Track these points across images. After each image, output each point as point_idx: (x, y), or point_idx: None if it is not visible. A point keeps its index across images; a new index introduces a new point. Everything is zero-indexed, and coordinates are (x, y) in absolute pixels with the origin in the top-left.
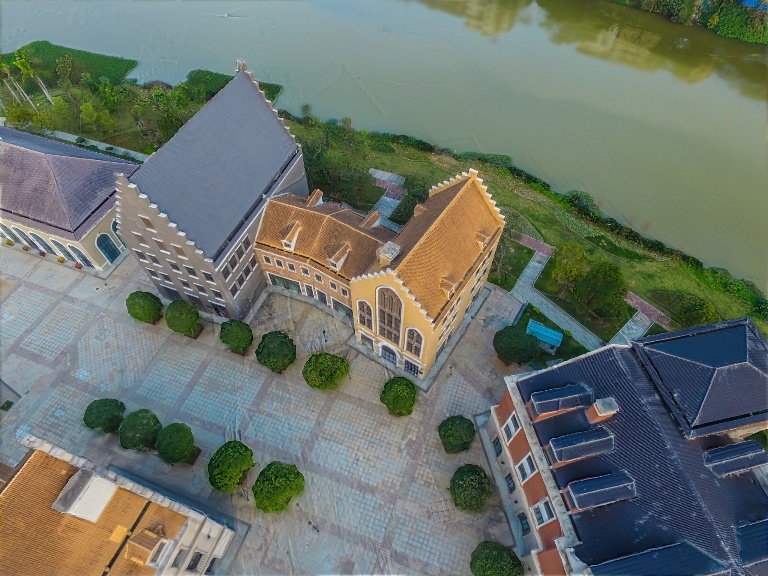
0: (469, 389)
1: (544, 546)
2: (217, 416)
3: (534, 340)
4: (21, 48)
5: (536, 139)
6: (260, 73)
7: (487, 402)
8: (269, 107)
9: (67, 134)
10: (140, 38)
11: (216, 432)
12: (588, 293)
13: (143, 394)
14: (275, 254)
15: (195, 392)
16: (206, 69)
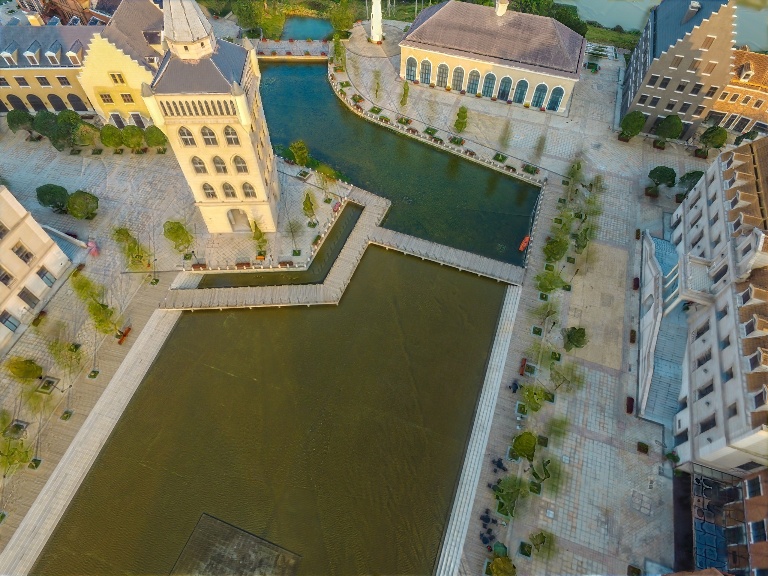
0: None
1: None
2: None
3: None
4: None
5: None
6: None
7: None
8: None
9: None
10: None
11: None
12: None
13: None
14: (731, 85)
15: None
16: None
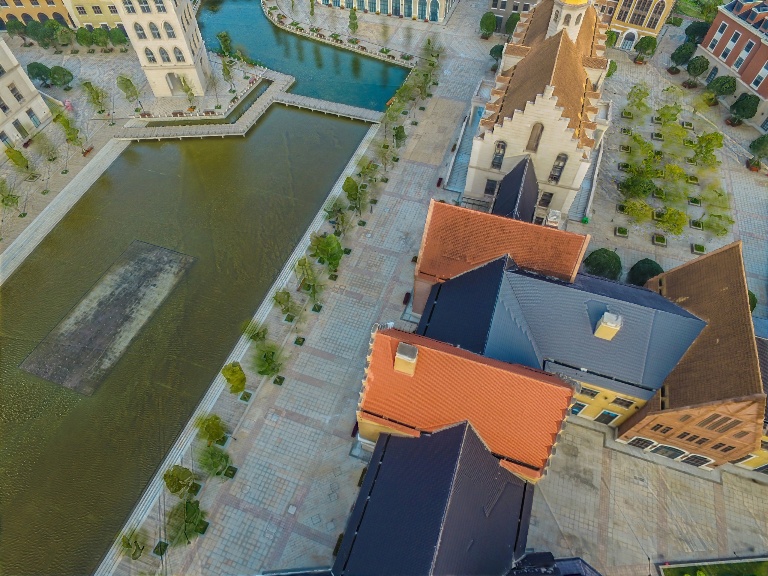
0: None
1: None
2: None
3: None
4: None
5: None
6: None
7: None
8: None
9: None
10: None
11: None
12: None
13: None
14: None
15: None
16: None
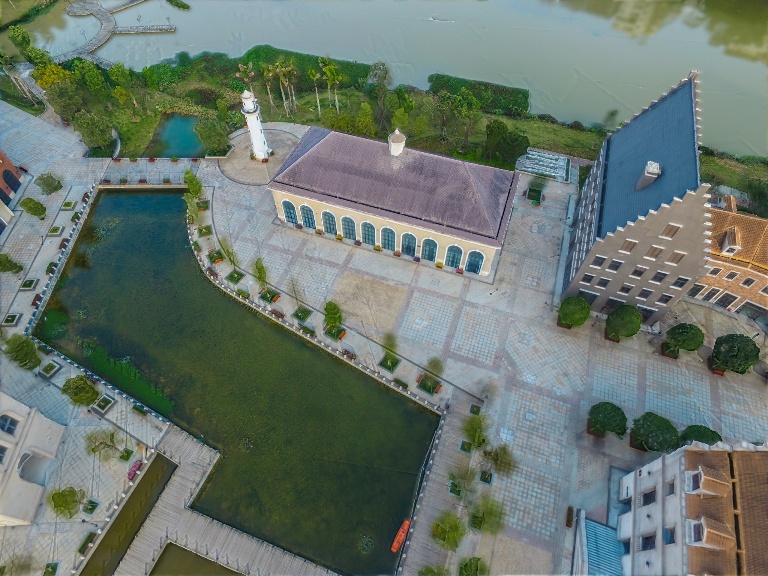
0: None
1: None
2: (685, 418)
3: None
4: (248, 52)
5: None
6: (498, 77)
7: None
8: None
9: None
10: (360, 42)
11: None
12: None
13: (600, 397)
14: None
15: (650, 394)
16: (443, 73)
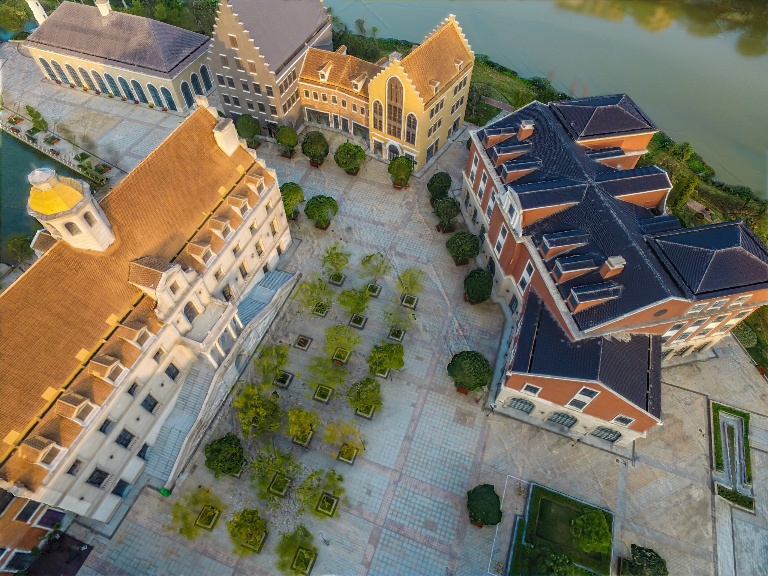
0: None
1: None
2: None
3: None
4: None
5: (509, 45)
6: None
7: None
8: None
9: None
10: None
11: None
12: None
13: None
14: (313, 85)
15: None
16: None
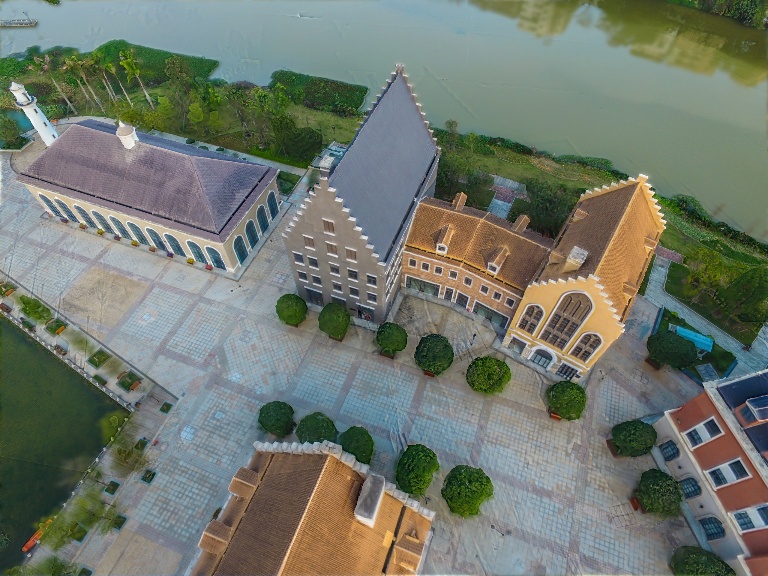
0: (623, 393)
1: (754, 551)
2: (378, 419)
3: (693, 345)
4: (99, 47)
5: (631, 142)
6: (343, 74)
7: (644, 406)
8: (418, 110)
9: (169, 134)
10: (217, 38)
11: (380, 435)
12: (738, 298)
13: (300, 397)
14: (426, 257)
15: (351, 395)
16: (289, 70)
